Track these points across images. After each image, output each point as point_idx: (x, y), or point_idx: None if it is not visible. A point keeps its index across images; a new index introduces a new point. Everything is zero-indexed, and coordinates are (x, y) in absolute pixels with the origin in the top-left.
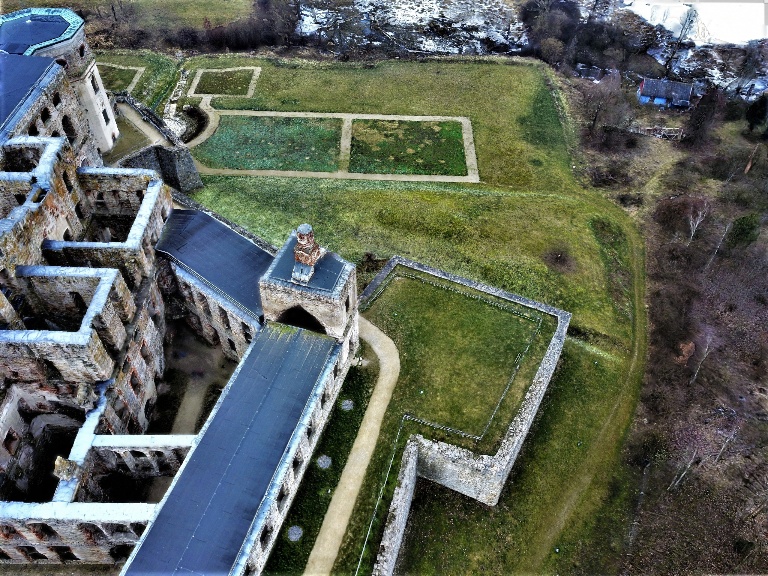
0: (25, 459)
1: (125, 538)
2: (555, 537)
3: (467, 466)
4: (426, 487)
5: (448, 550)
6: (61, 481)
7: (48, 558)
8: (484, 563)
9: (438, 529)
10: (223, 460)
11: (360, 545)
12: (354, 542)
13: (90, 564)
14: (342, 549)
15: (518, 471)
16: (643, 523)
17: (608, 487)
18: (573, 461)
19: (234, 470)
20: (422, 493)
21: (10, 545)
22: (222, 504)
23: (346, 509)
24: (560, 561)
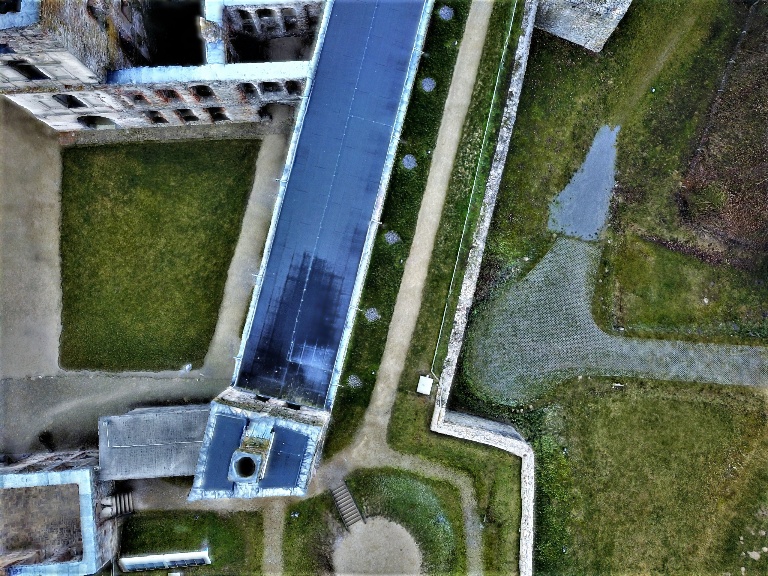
0: (140, 26)
1: (276, 96)
2: (653, 79)
3: (588, 11)
4: (536, 36)
5: (556, 95)
6: (209, 44)
7: (201, 119)
8: (588, 105)
9: (547, 76)
10: (366, 13)
11: (490, 92)
12: (485, 90)
13: (238, 123)
14: (474, 96)
15: (624, 16)
16: (739, 61)
17: (710, 28)
18: (680, 2)
19: (379, 23)
20: (532, 43)
21: (169, 109)
22: (375, 57)
23: (474, 60)
24: (655, 100)
